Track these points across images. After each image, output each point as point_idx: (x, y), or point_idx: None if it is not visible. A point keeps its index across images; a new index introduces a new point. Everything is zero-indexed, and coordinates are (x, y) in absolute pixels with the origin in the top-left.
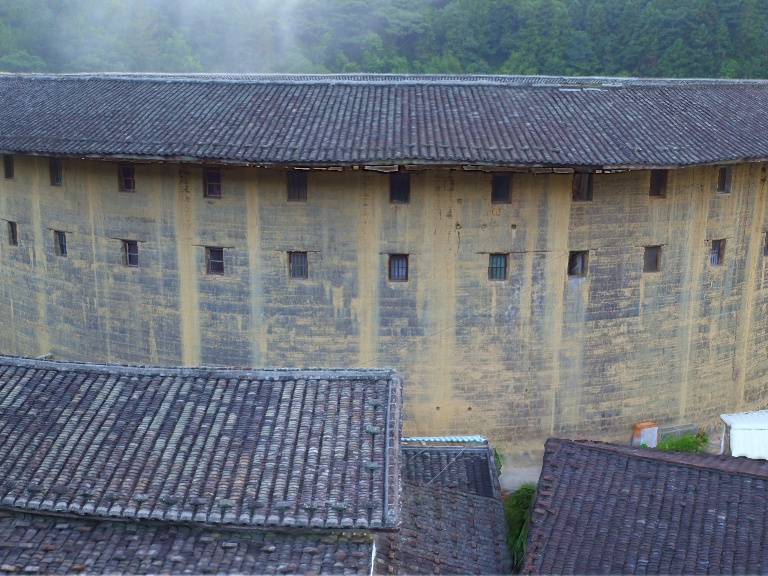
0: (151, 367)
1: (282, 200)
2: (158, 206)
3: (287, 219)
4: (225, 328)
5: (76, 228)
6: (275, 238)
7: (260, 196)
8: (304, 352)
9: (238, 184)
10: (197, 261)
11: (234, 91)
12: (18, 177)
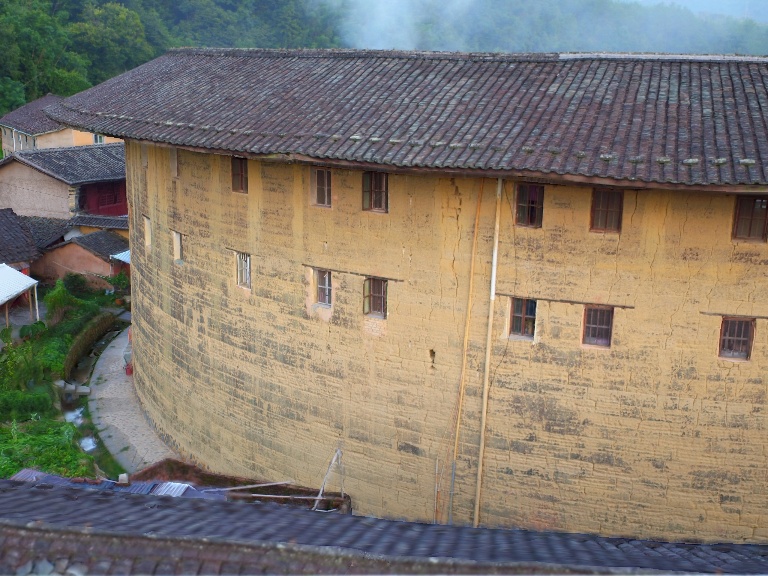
0: (75, 147)
1: None
2: None
3: None
4: None
5: None
6: None
7: None
8: None
9: None
10: None
11: None
12: None
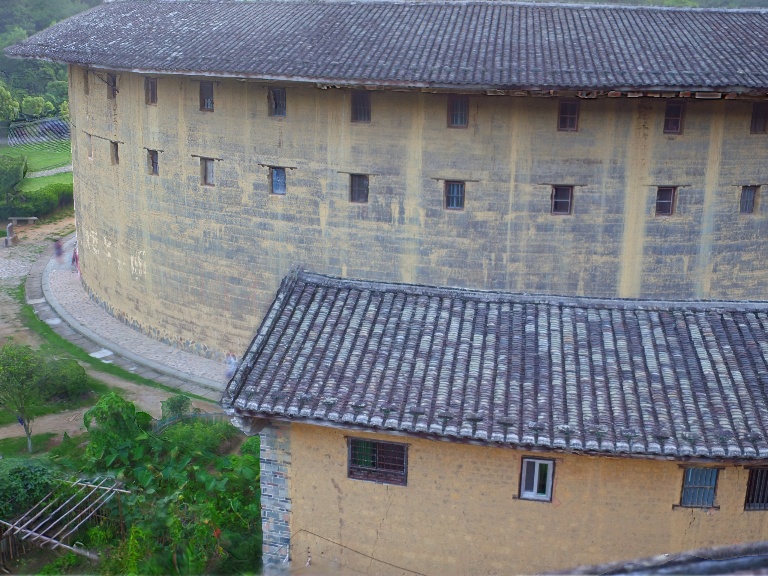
0: None
1: (746, 133)
2: (608, 145)
3: (748, 152)
4: (669, 271)
5: (486, 175)
6: (734, 173)
7: (725, 129)
8: (744, 288)
9: (704, 118)
10: (647, 202)
11: (679, 18)
12: (382, 120)
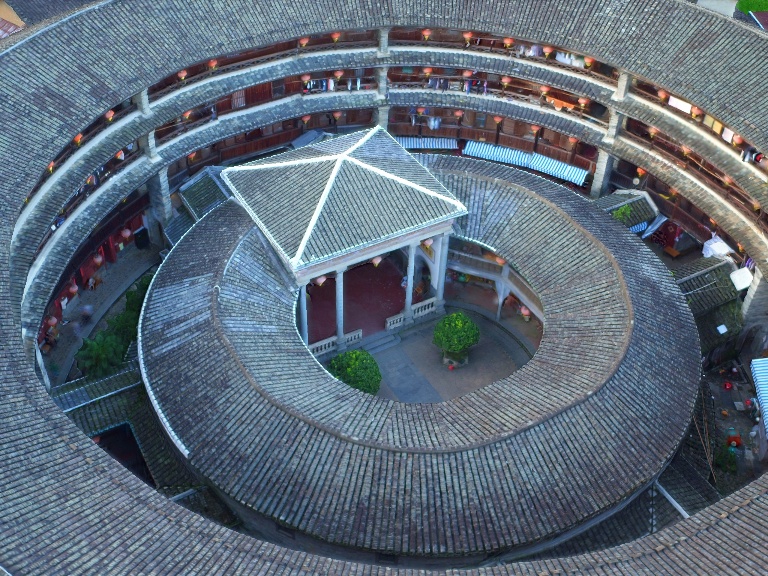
0: None
1: None
2: None
3: None
4: None
5: None
6: None
7: None
8: None
9: None
10: None
11: None
12: None
